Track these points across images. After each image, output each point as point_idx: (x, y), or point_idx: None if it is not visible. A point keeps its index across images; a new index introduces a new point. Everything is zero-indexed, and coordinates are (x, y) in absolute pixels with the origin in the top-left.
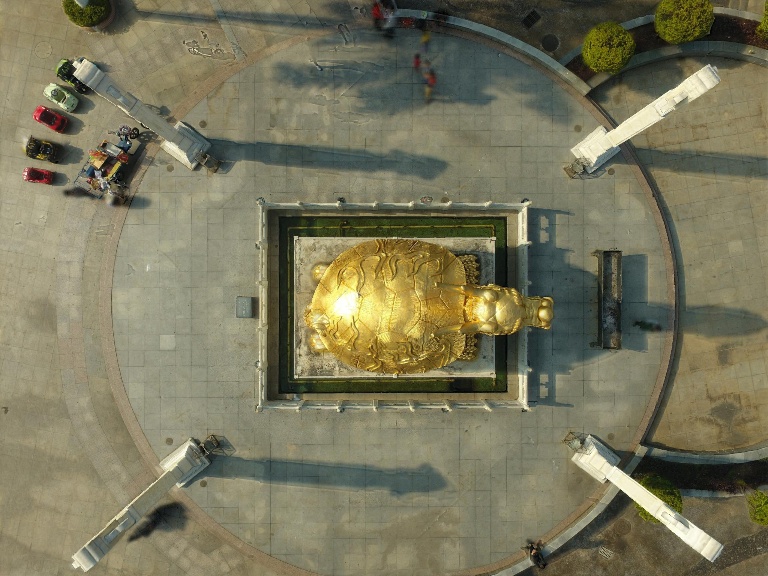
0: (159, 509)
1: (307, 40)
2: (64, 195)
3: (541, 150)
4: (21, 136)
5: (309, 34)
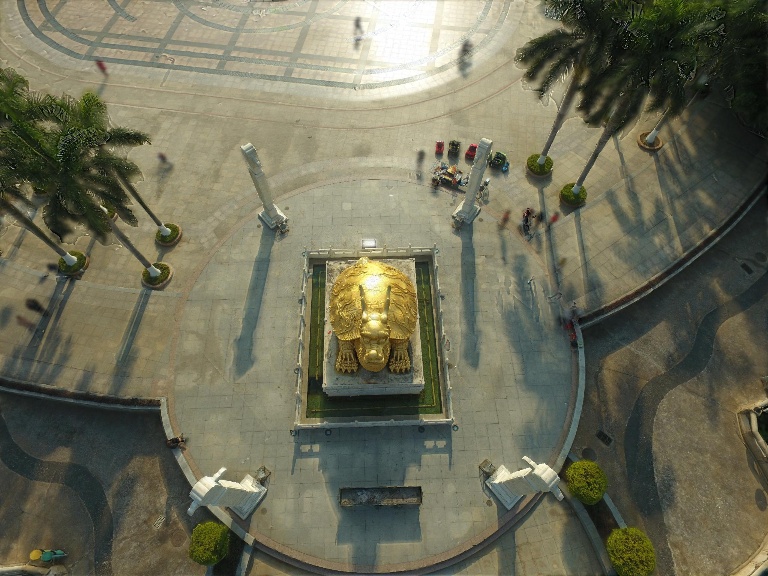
0: (246, 206)
1: (546, 274)
2: (431, 158)
3: (498, 440)
4: (461, 140)
5: (550, 275)
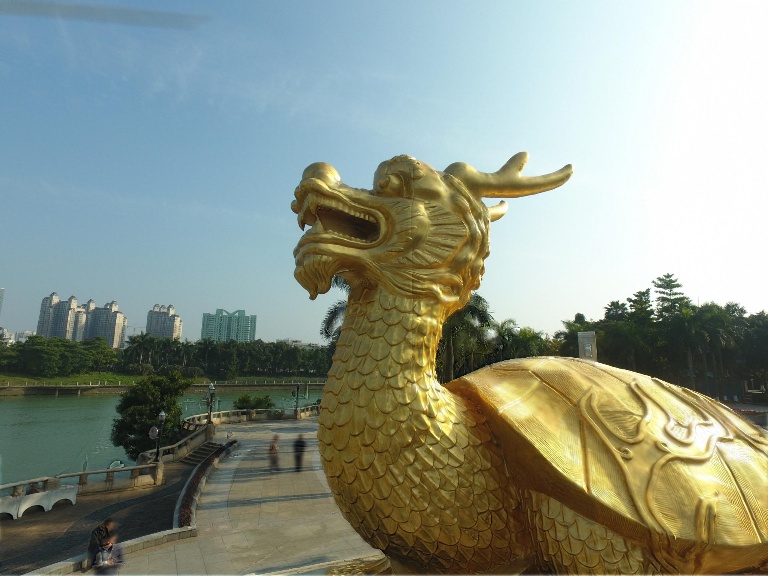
0: None
1: None
2: None
3: None
4: None
5: None
